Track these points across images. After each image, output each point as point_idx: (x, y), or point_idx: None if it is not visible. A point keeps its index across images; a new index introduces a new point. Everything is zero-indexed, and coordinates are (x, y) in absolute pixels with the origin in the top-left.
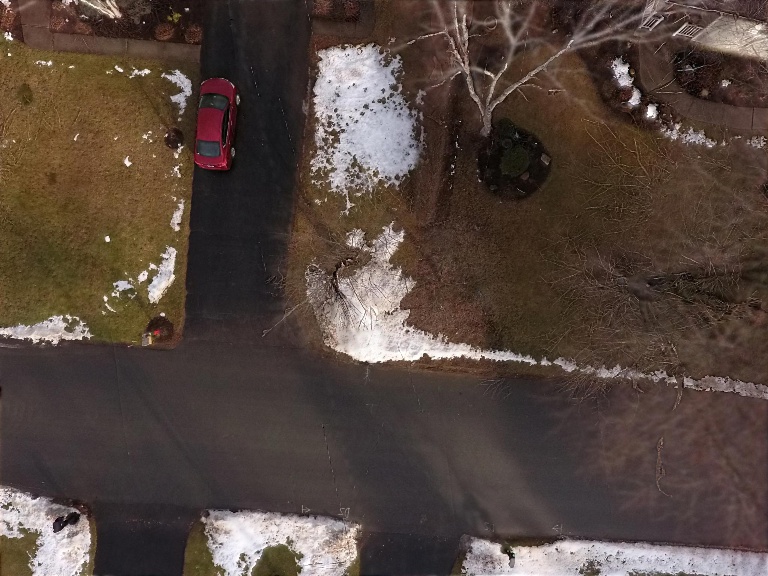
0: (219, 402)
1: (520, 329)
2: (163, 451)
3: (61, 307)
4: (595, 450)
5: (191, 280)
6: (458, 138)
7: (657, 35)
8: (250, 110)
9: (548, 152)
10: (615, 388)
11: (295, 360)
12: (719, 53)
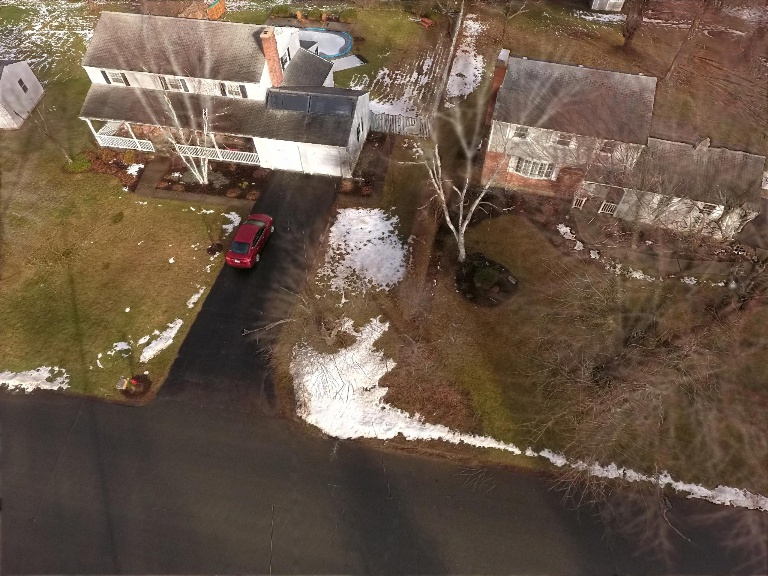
0: (165, 466)
1: (500, 415)
2: (76, 522)
3: (55, 359)
4: (608, 574)
5: (186, 346)
6: (440, 264)
7: (587, 213)
8: (279, 237)
9: (514, 276)
10: (616, 492)
11: (262, 428)
12: (637, 226)
